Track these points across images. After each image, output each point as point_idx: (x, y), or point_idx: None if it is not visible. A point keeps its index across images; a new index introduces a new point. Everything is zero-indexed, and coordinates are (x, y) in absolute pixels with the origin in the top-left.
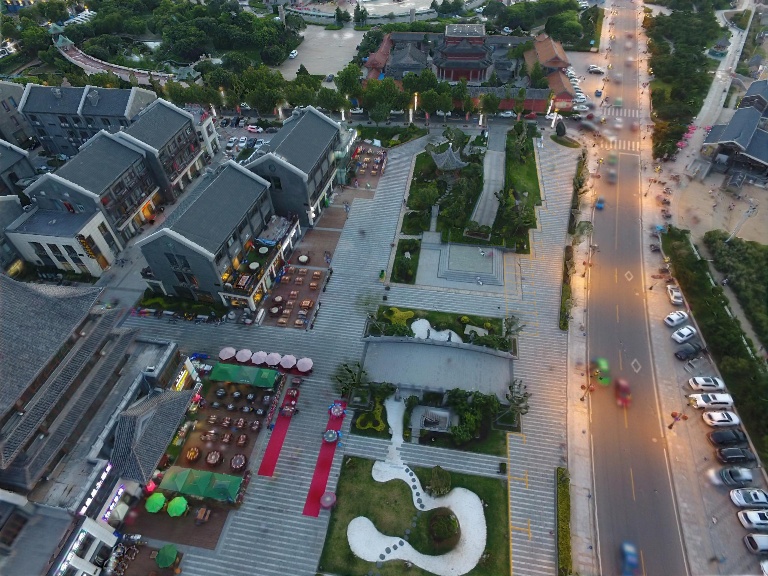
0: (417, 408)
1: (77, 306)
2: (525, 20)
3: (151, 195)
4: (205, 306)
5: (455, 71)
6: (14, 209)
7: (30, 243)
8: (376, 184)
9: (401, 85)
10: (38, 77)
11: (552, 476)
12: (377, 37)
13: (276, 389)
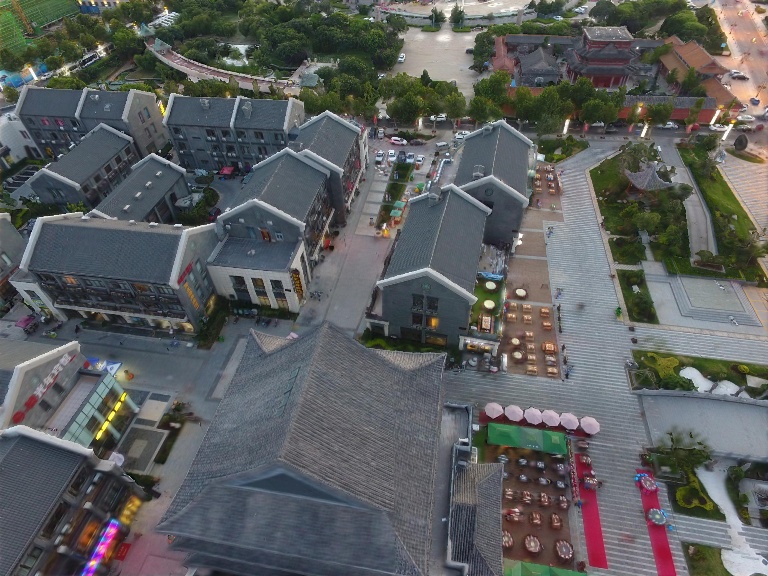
0: (742, 481)
1: (428, 379)
2: (639, 21)
3: (330, 218)
4: (435, 349)
5: (595, 77)
6: (213, 239)
7: (231, 277)
8: (560, 204)
9: None
10: (144, 83)
11: None
12: (488, 40)
13: (566, 455)
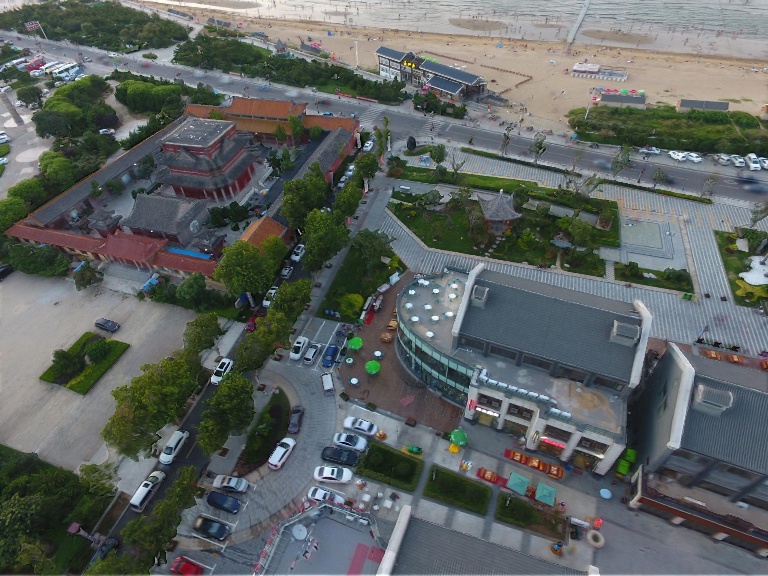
0: None
1: None
2: (108, 112)
3: None
4: None
5: (238, 179)
6: None
7: None
8: None
9: (288, 219)
10: None
11: None
12: None
13: None
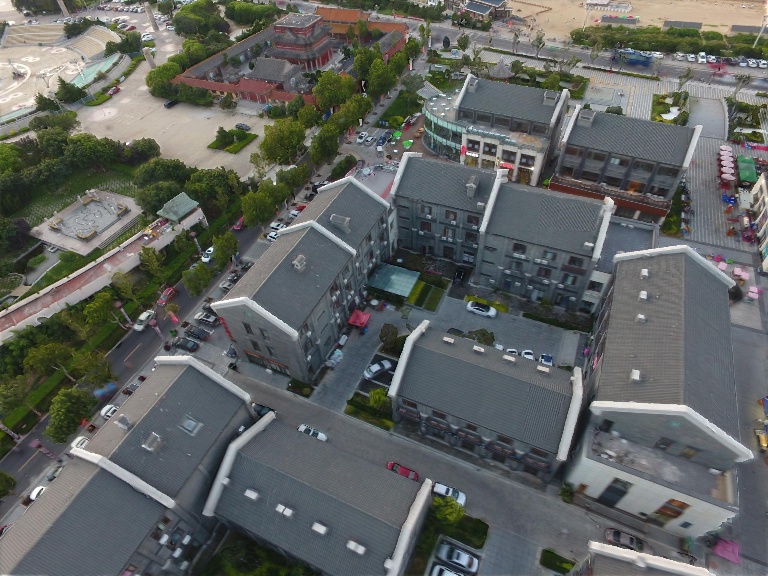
0: None
1: None
2: (223, 21)
3: None
4: None
5: (321, 57)
6: None
7: None
8: None
9: (357, 71)
10: None
11: (761, 98)
12: None
13: None
